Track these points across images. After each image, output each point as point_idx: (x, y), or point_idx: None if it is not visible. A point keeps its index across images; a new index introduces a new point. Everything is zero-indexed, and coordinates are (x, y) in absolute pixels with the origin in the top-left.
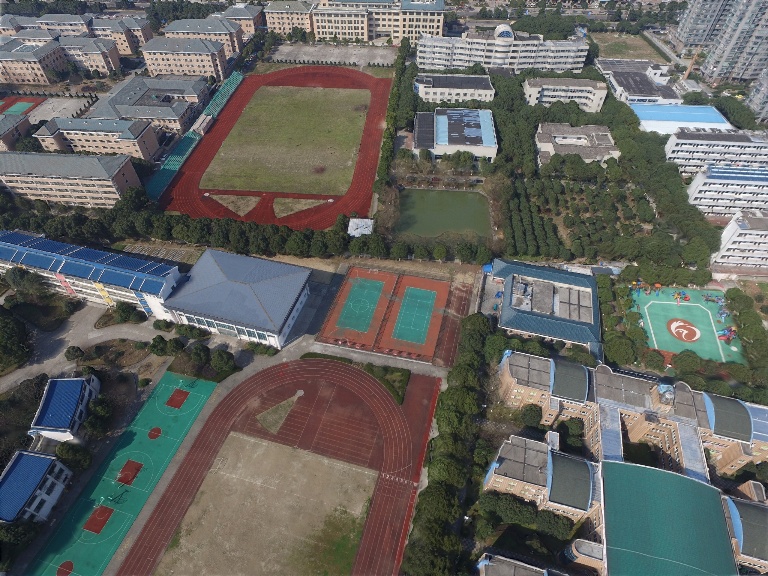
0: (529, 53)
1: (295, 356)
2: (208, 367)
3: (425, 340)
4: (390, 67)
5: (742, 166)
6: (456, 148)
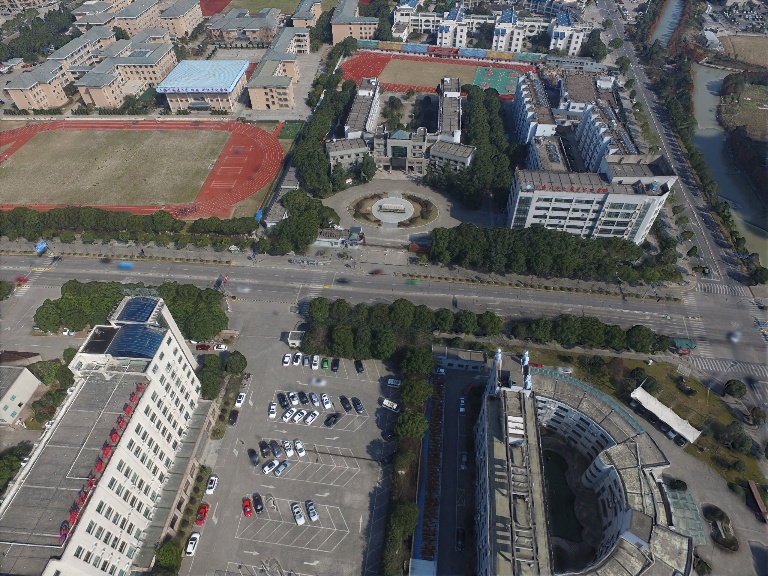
0: None
1: None
2: None
3: None
4: None
5: None
6: None
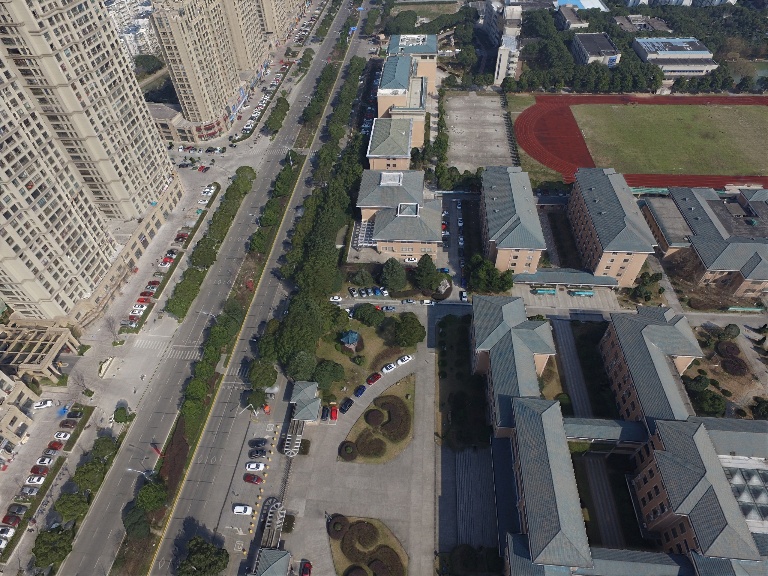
0: None
1: None
2: None
3: None
4: None
5: None
6: None
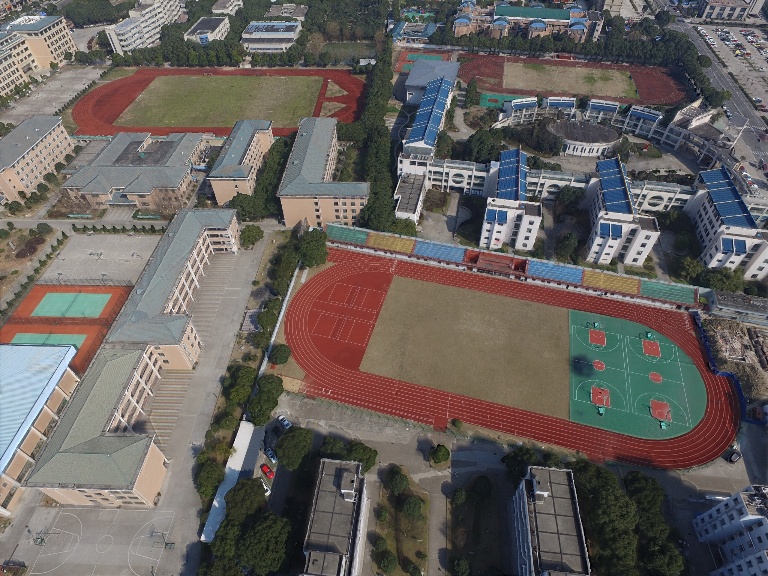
0: (167, 7)
1: (458, 79)
2: (476, 92)
3: None
4: (112, 70)
5: None
6: (297, 31)
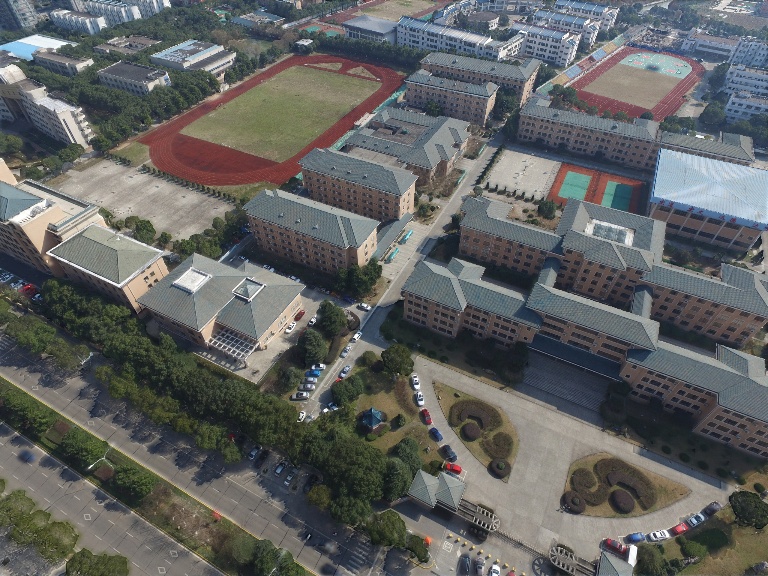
0: None
1: None
2: None
3: (312, 26)
4: None
5: (110, 5)
6: None
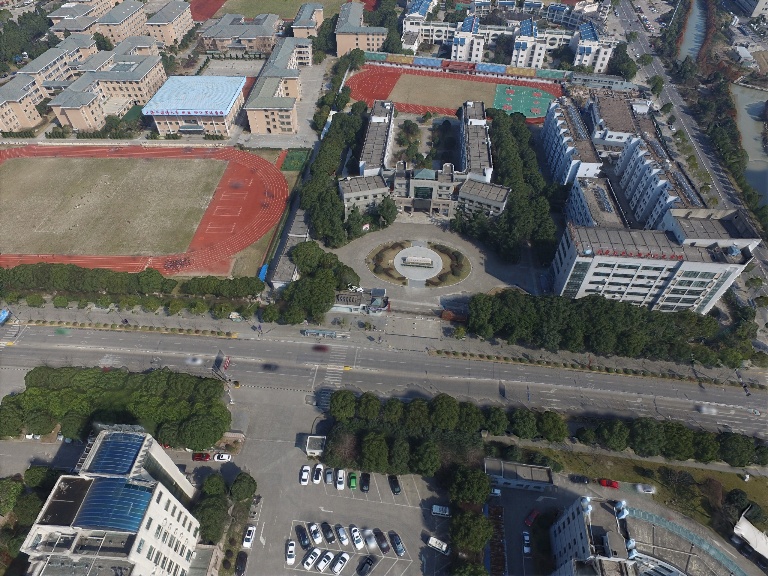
0: None
1: None
2: None
3: None
4: None
5: None
6: None
